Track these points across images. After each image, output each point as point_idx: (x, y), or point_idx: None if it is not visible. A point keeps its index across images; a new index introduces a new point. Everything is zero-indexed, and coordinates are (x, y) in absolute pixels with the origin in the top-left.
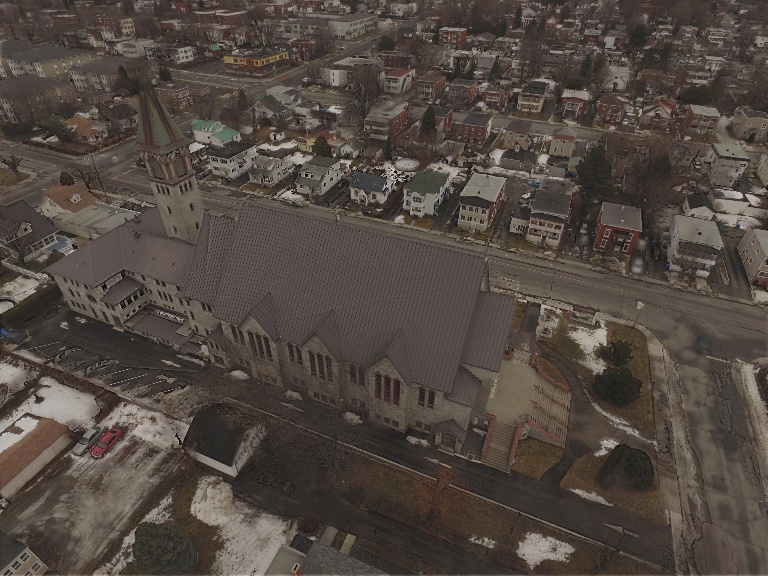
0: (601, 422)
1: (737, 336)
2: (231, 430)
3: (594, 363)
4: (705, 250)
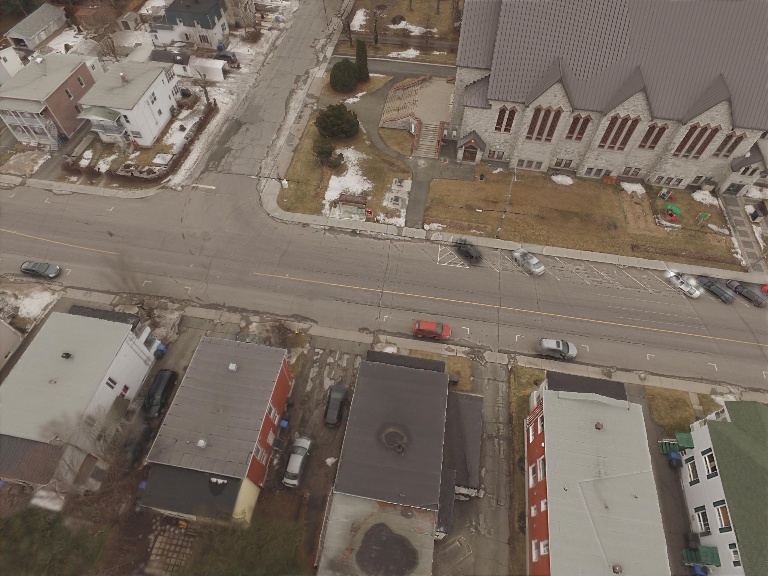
0: (356, 112)
1: (152, 220)
2: None
3: (350, 157)
4: (95, 312)
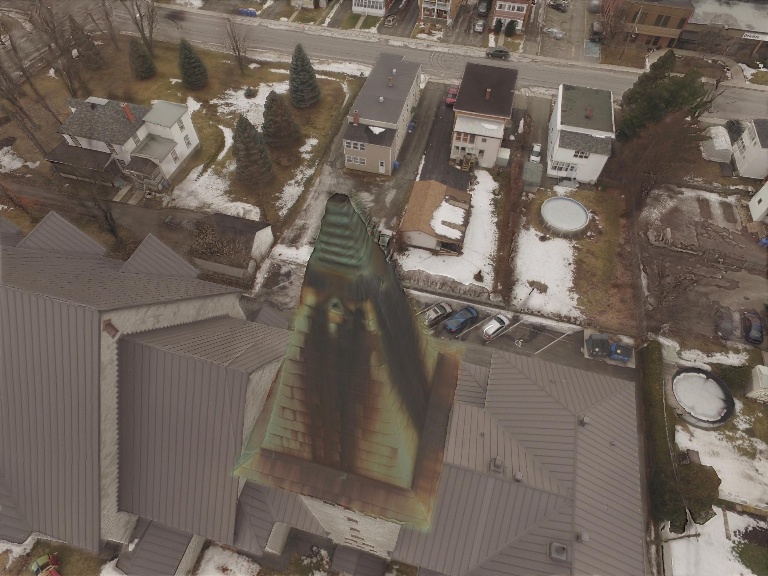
0: None
1: None
2: (214, 221)
3: None
4: None
